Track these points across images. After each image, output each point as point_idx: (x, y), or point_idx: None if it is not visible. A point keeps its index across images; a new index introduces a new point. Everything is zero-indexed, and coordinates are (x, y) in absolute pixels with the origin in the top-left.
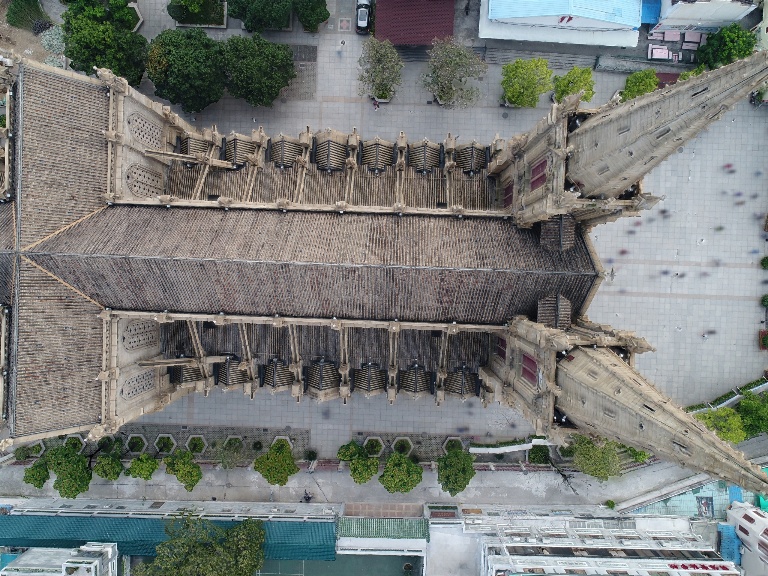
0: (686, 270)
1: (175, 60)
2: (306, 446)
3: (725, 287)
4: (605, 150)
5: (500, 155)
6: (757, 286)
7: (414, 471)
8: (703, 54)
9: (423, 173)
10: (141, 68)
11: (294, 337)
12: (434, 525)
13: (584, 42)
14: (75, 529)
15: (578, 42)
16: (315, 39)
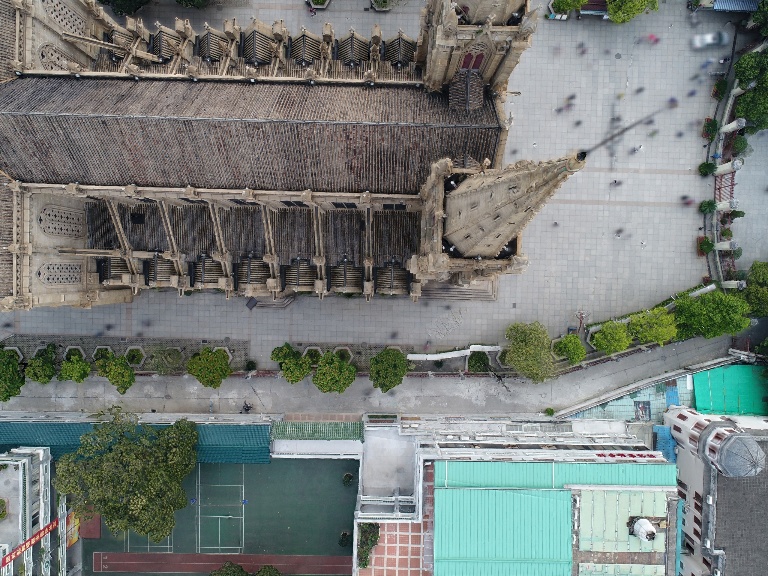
0: (624, 177)
1: None
2: (246, 357)
3: (663, 194)
4: None
5: None
6: (695, 193)
7: (346, 369)
8: None
9: (351, 66)
10: None
11: (217, 225)
12: (369, 428)
13: None
14: (8, 434)
15: None
16: None
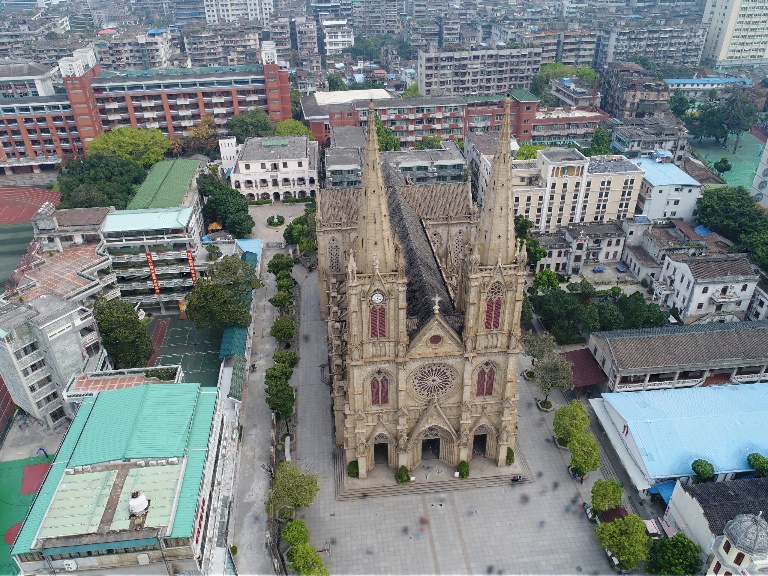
0: None
1: None
2: None
3: None
4: None
5: None
6: None
7: None
8: None
9: None
10: None
11: None
12: None
13: (621, 456)
14: None
15: (619, 452)
16: None
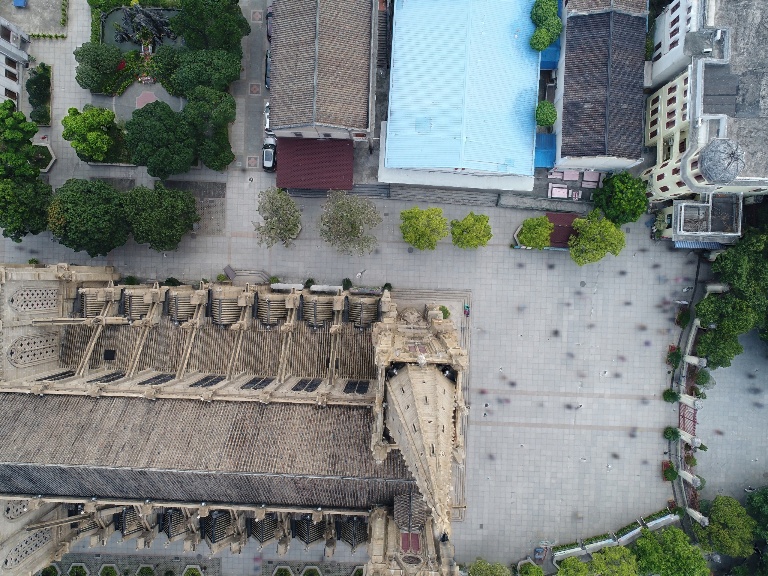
0: (590, 402)
1: (73, 218)
2: (217, 574)
3: (628, 419)
4: (395, 433)
5: (385, 317)
6: (660, 418)
7: None
8: (598, 198)
9: (315, 328)
10: (46, 217)
11: None
12: None
13: (481, 186)
14: None
15: (475, 186)
16: (224, 176)
